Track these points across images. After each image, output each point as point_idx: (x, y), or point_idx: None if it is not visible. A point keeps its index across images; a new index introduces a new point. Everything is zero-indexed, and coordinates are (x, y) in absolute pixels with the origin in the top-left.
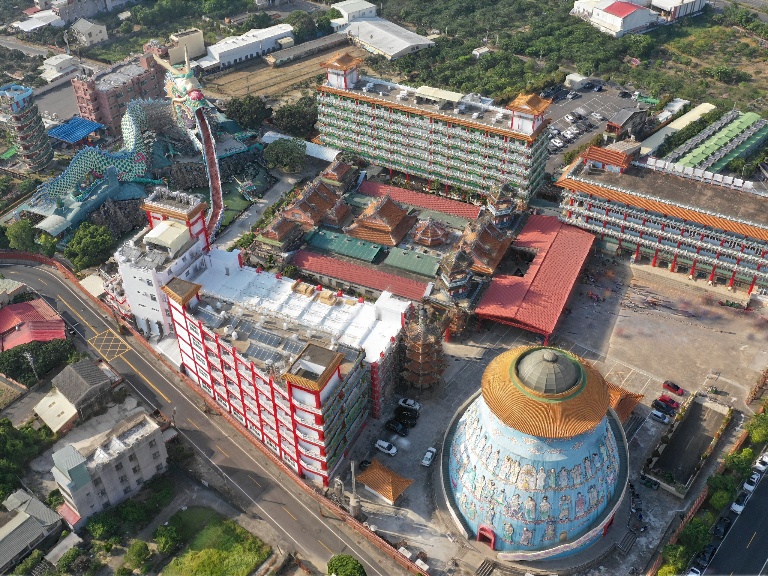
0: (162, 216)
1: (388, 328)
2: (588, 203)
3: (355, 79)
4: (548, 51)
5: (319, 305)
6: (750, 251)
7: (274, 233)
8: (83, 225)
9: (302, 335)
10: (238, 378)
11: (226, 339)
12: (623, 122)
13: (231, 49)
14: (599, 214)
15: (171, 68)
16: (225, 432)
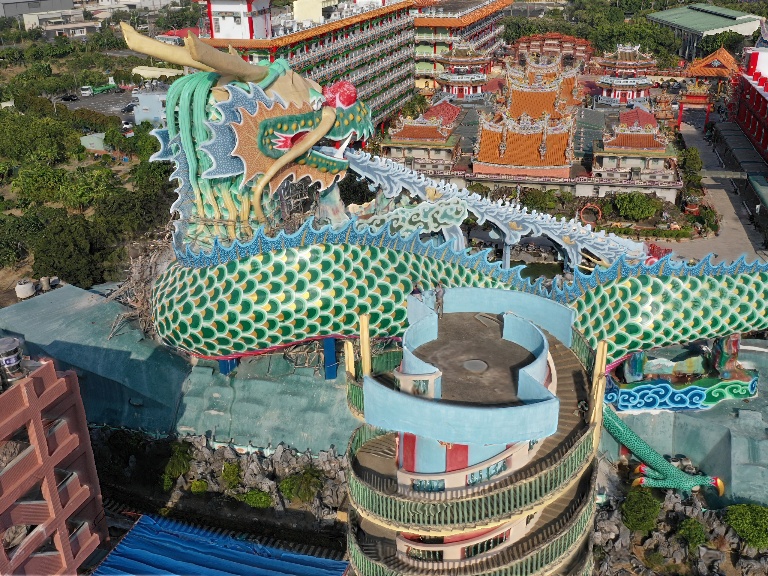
0: None
1: None
2: None
3: None
4: None
5: None
6: None
7: None
8: None
9: None
10: None
11: None
12: None
13: None
14: None
15: None
16: None
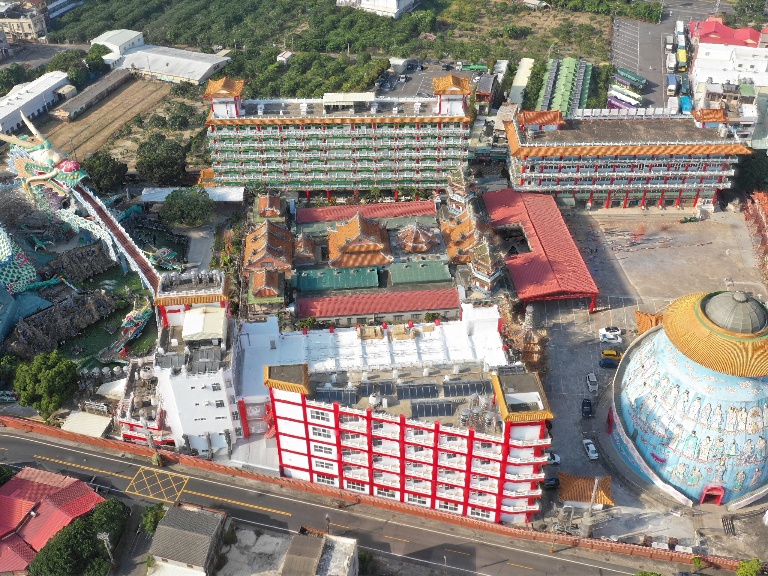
0: (187, 306)
1: (486, 340)
2: (545, 165)
3: (240, 104)
4: (349, 43)
5: (401, 343)
6: (693, 168)
7: (268, 290)
8: (6, 361)
9: (449, 375)
10: (402, 449)
11: (378, 410)
12: (490, 89)
13: (11, 112)
14: (555, 173)
15: (20, 141)
16: (380, 518)
